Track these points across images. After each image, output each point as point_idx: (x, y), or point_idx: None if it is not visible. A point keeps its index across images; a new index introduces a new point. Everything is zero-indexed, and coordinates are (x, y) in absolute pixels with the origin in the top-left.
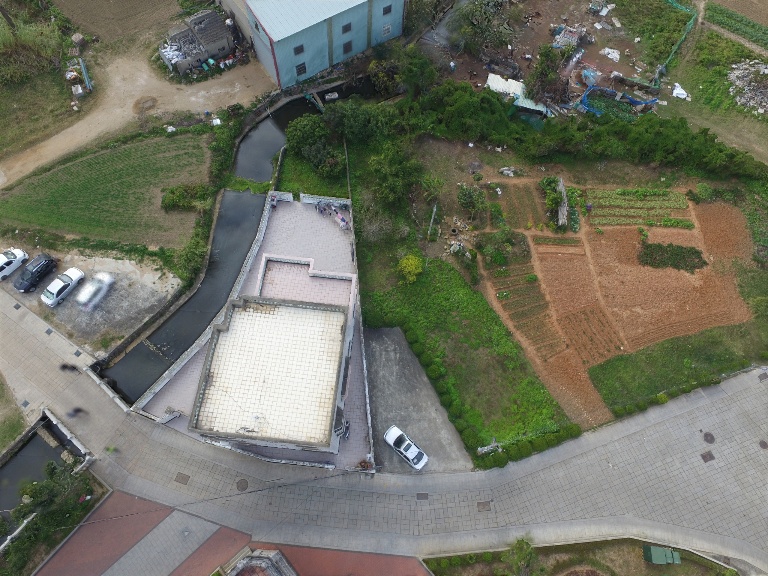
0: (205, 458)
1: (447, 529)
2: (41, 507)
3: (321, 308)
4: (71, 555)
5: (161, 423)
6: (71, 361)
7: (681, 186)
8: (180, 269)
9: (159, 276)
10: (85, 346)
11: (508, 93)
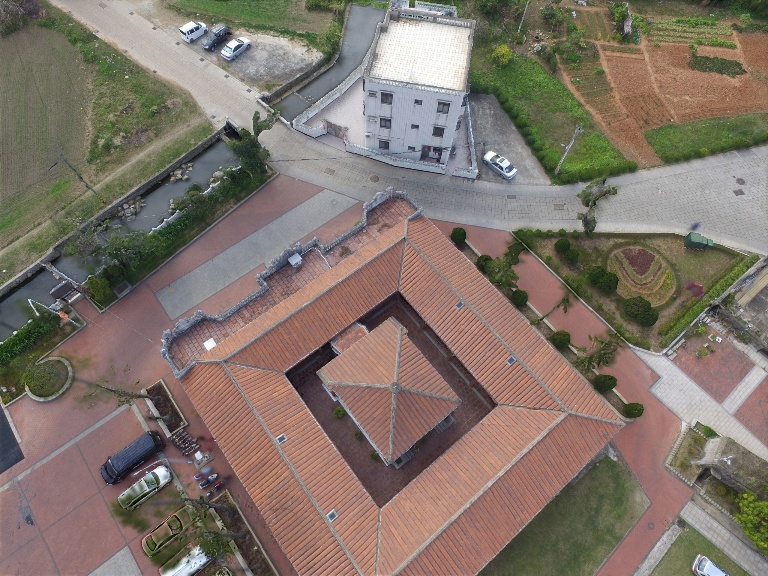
0: (346, 161)
1: (530, 217)
2: (245, 148)
3: (454, 23)
4: (251, 207)
5: (313, 137)
6: (244, 94)
7: (727, 20)
8: (322, 46)
9: (306, 50)
10: (254, 87)
11: None
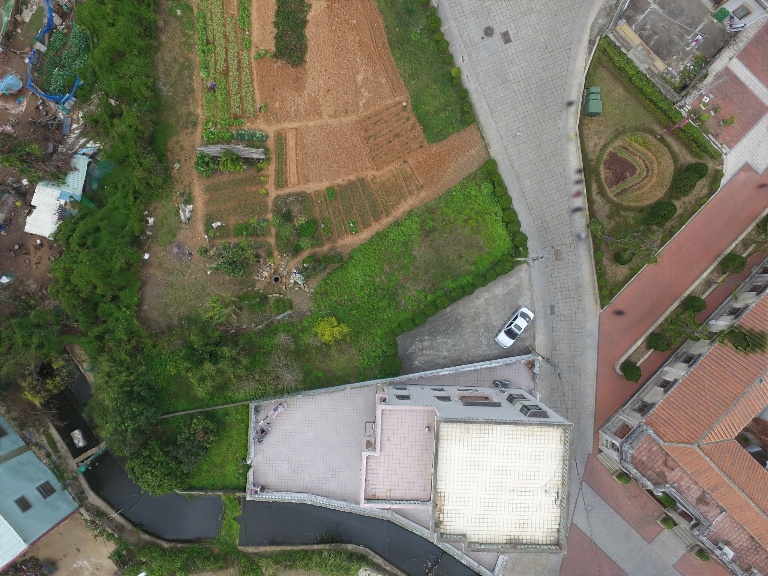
0: None
1: (577, 288)
2: None
3: None
4: None
5: None
6: None
7: None
8: (349, 573)
9: None
10: None
11: (60, 207)
